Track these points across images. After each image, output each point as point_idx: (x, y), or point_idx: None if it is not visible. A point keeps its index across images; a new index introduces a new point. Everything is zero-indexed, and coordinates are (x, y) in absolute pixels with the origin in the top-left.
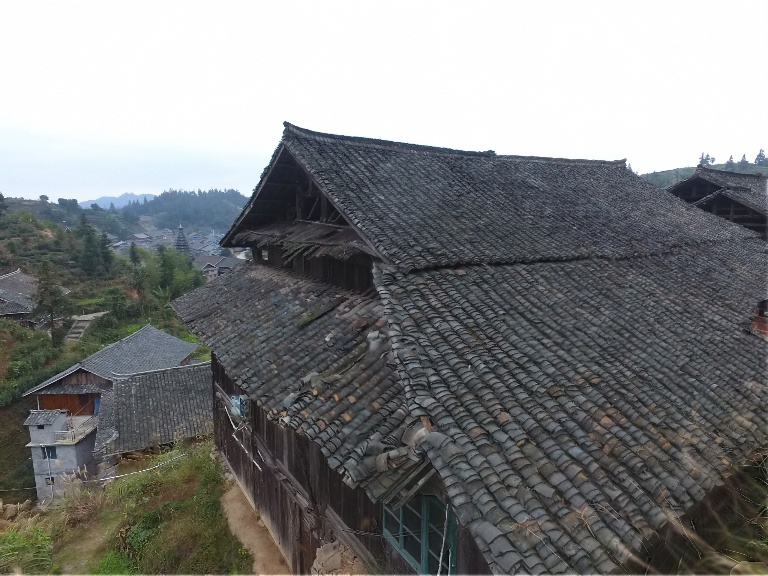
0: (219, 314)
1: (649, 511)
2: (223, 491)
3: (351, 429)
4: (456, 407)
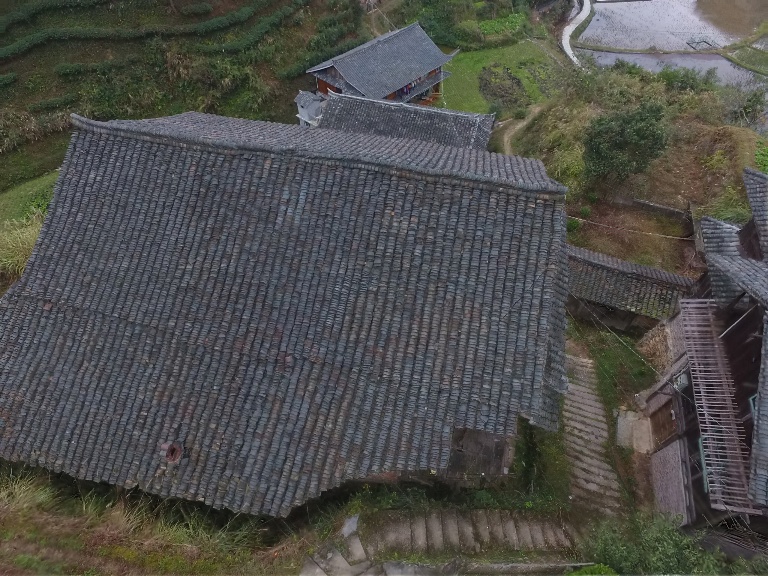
0: None
1: None
2: None
3: None
4: None
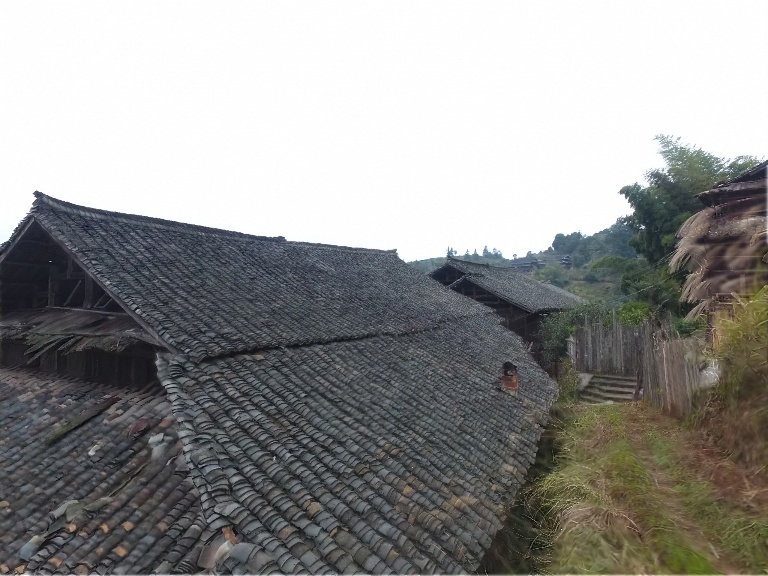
0: None
1: (453, 572)
2: None
3: (127, 566)
4: (263, 507)
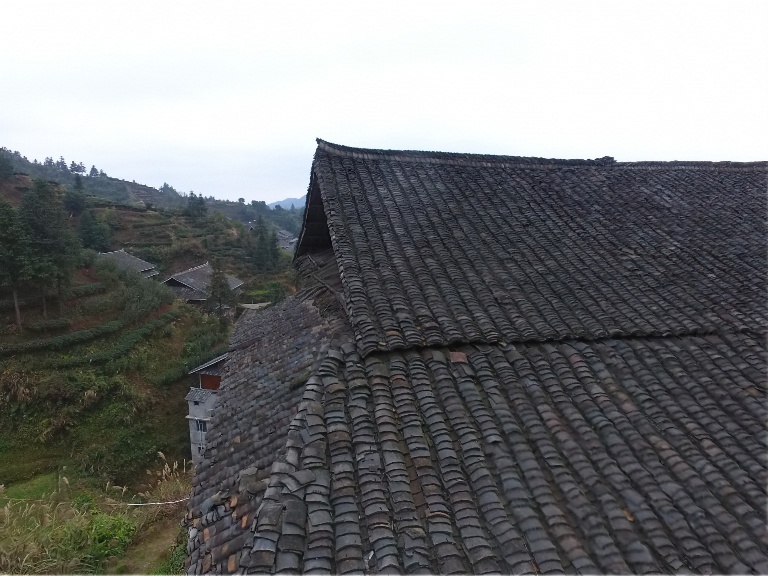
0: (253, 348)
1: None
2: None
3: None
4: None
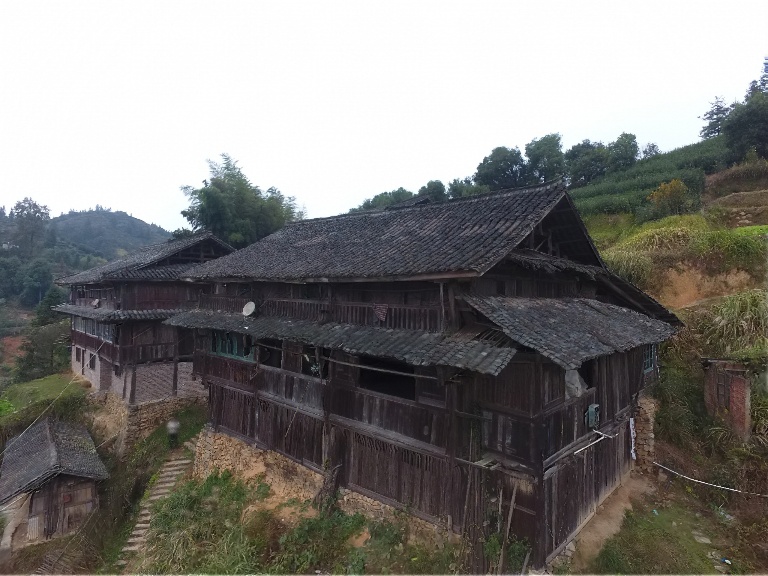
0: None
1: None
2: (576, 574)
3: None
4: None
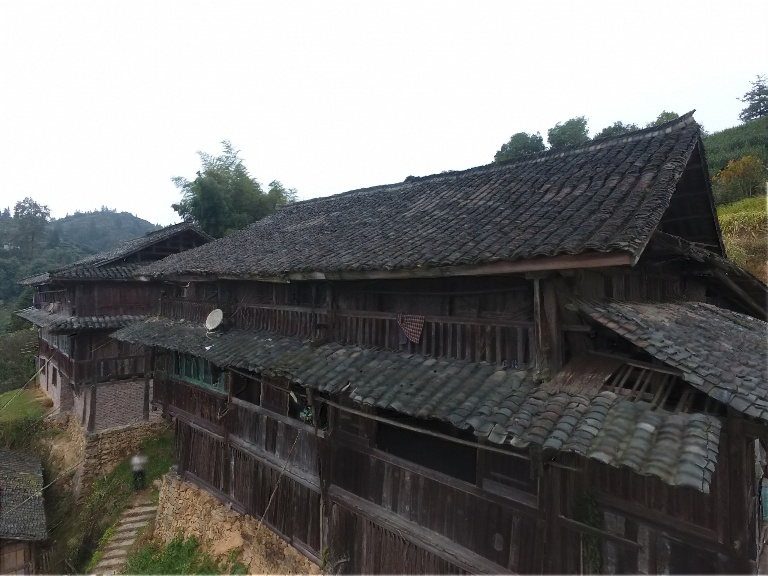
0: None
1: None
2: None
3: None
4: None
